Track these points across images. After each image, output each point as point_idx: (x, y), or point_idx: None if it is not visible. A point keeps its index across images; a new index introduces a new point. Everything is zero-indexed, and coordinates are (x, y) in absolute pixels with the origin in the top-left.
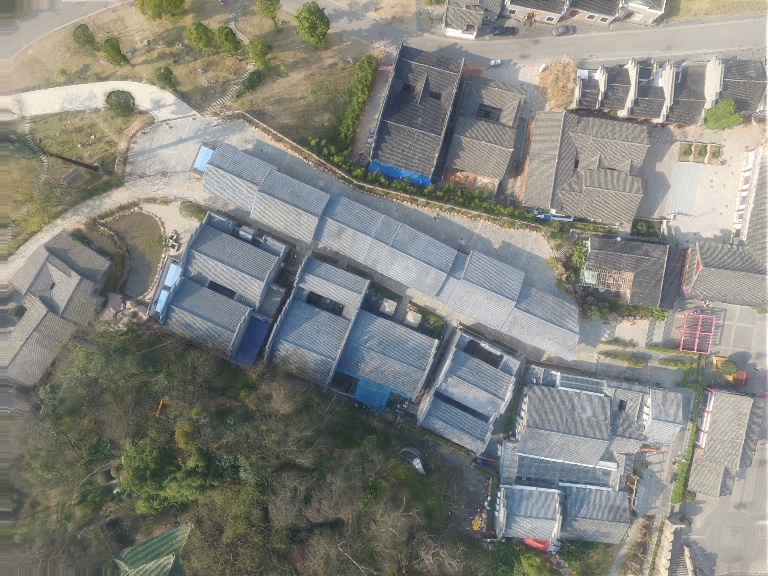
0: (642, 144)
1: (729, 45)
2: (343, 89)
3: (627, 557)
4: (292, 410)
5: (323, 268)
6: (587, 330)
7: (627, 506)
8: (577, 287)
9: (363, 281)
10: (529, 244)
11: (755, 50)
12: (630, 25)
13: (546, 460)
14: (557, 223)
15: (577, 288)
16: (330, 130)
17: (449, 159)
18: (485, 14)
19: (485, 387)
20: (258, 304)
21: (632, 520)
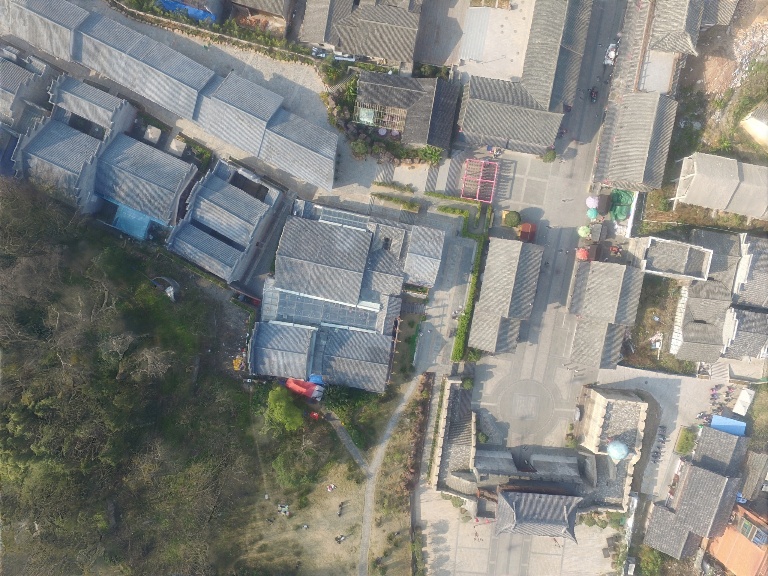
0: None
1: None
2: None
3: (404, 415)
4: (17, 210)
5: (81, 87)
6: (360, 169)
7: (389, 349)
8: (349, 123)
9: None
10: (301, 77)
11: None
12: None
13: (308, 298)
14: (329, 56)
15: (349, 124)
16: None
17: None
18: None
19: (238, 213)
20: (13, 120)
21: (411, 376)
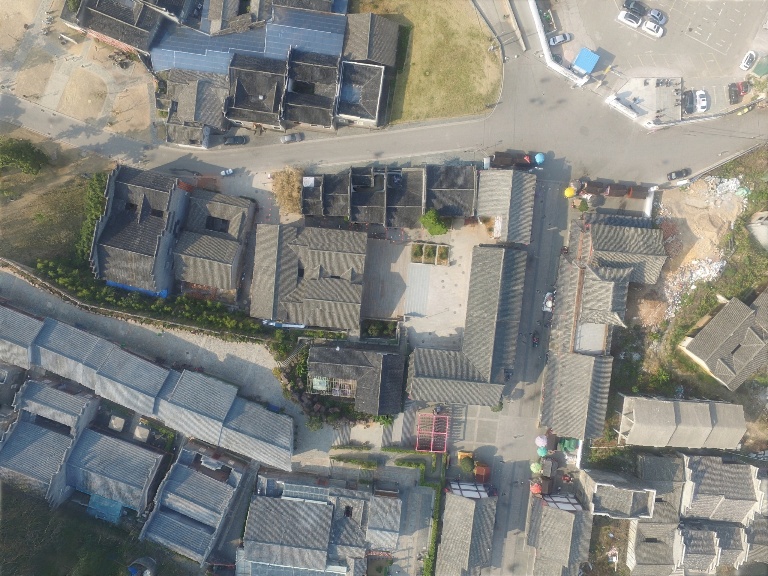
0: (358, 254)
1: (452, 146)
2: (81, 205)
3: None
4: None
5: (43, 392)
6: (318, 436)
7: None
8: (304, 395)
9: (83, 403)
10: (253, 356)
11: (476, 151)
12: (356, 130)
13: (278, 566)
14: (279, 335)
15: (303, 397)
16: (70, 246)
17: (176, 274)
18: (212, 126)
19: (204, 502)
20: None
21: None
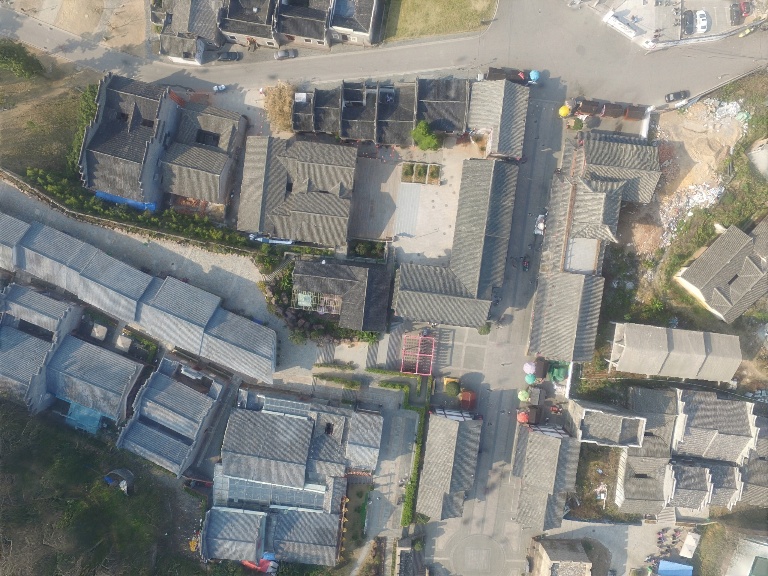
0: (347, 167)
1: (446, 64)
2: (74, 118)
3: None
4: None
5: (27, 295)
6: (301, 353)
7: (336, 529)
8: (288, 310)
9: (66, 308)
10: (239, 268)
11: (470, 68)
12: (350, 47)
13: (256, 482)
14: (265, 247)
15: (287, 311)
16: (61, 158)
17: (164, 185)
18: (206, 40)
19: (182, 411)
20: None
21: (363, 542)
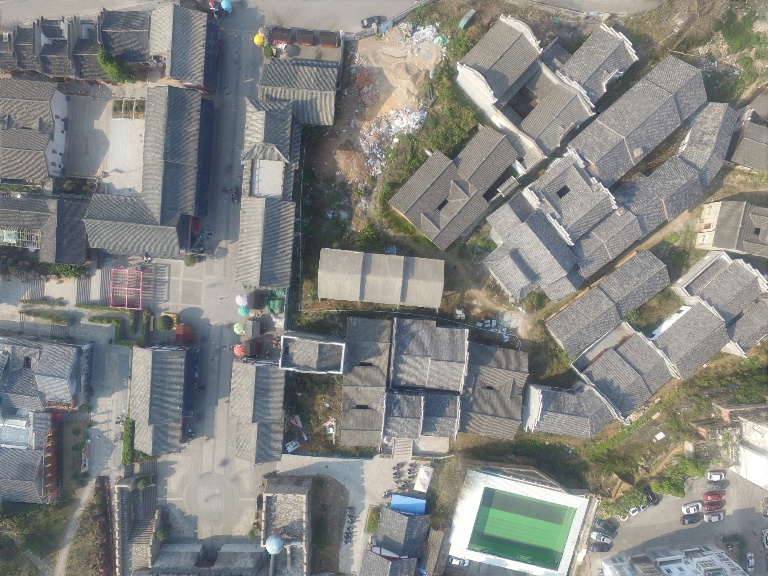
0: (42, 101)
1: None
2: None
3: (82, 519)
4: None
5: None
6: (6, 289)
7: (38, 464)
8: None
9: None
10: None
11: (169, 1)
12: None
13: None
14: None
15: None
16: None
17: None
18: None
19: None
20: None
21: (85, 481)
